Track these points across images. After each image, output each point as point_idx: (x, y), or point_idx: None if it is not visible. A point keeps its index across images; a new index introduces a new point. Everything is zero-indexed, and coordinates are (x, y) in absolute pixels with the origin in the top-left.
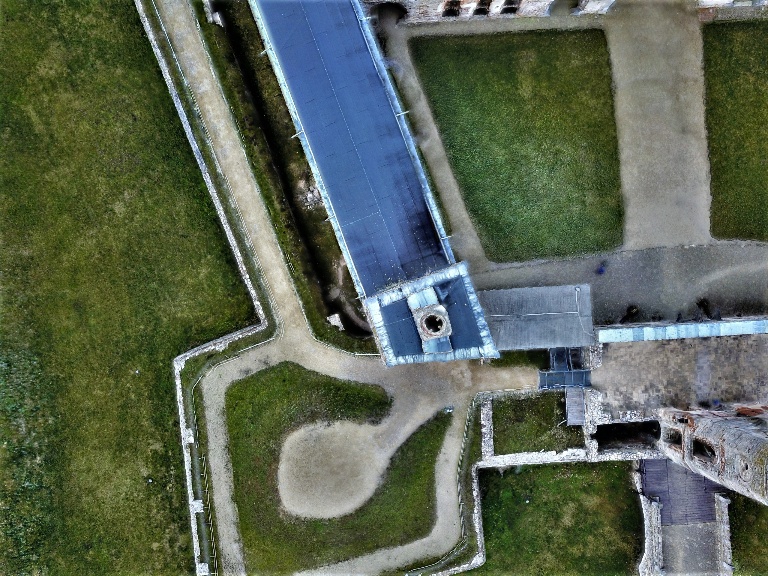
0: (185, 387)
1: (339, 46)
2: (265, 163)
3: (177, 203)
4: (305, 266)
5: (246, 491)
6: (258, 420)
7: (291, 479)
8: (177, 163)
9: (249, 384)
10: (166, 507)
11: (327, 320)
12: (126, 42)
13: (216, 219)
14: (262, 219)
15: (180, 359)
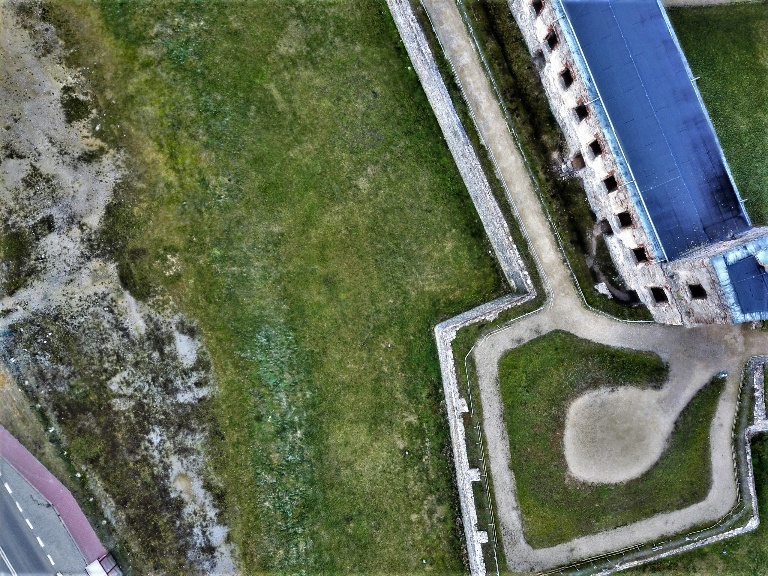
0: (457, 357)
1: (634, 13)
2: (528, 134)
3: (420, 178)
4: (572, 235)
5: (525, 458)
6: (534, 388)
7: (577, 445)
8: (419, 138)
9: (521, 353)
10: (423, 479)
11: (595, 288)
12: (364, 19)
13: (459, 193)
14: (527, 190)
15: (450, 330)
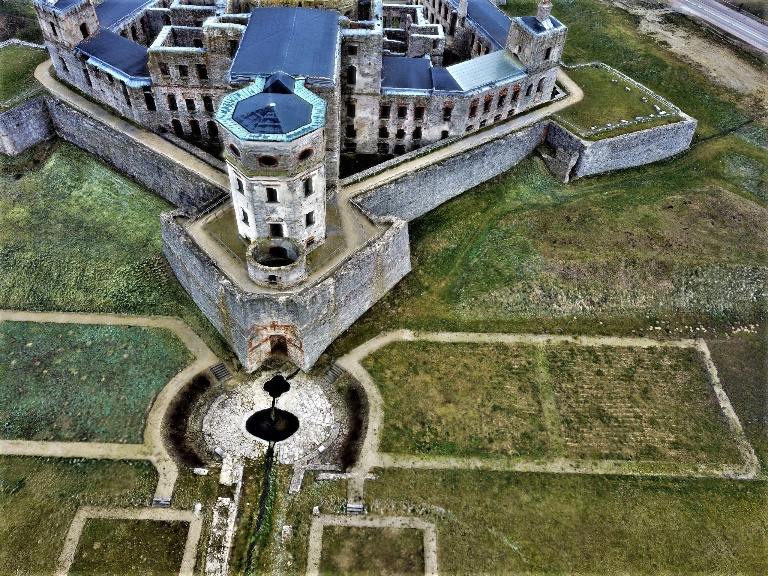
0: None
1: None
2: None
3: None
4: None
5: None
6: None
7: None
8: None
9: None
10: None
11: None
12: None
13: None
14: None
15: None
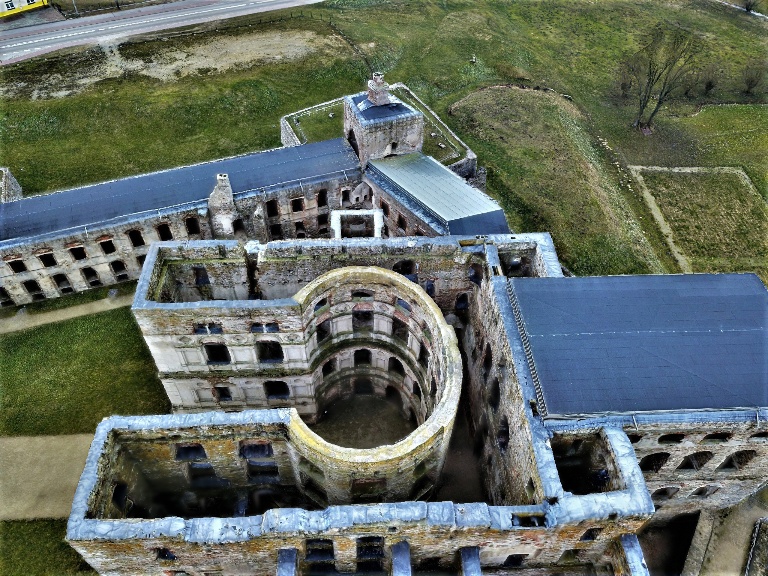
0: None
1: (142, 200)
2: None
3: None
4: None
5: None
6: None
7: None
8: None
9: None
10: None
11: None
12: None
13: None
14: None
15: (5, 169)
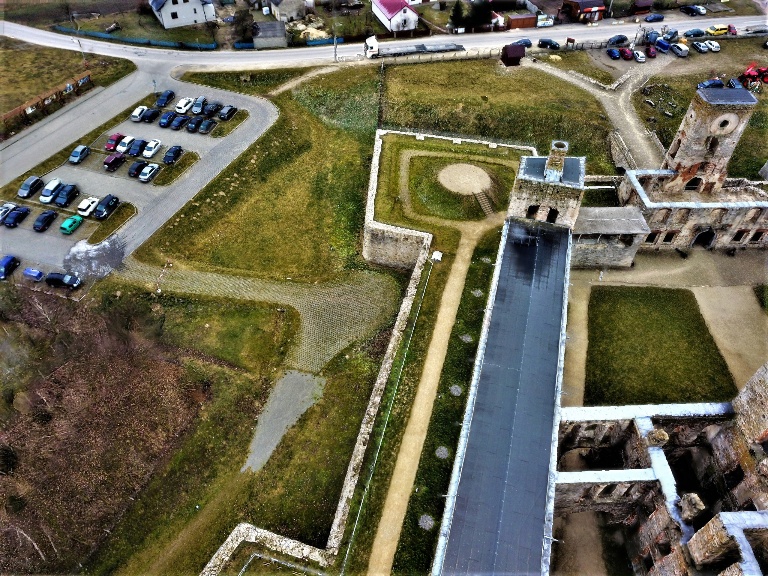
0: None
1: None
2: None
3: None
4: None
5: None
6: None
7: None
8: None
9: None
10: None
11: None
12: None
13: None
14: None
15: None
